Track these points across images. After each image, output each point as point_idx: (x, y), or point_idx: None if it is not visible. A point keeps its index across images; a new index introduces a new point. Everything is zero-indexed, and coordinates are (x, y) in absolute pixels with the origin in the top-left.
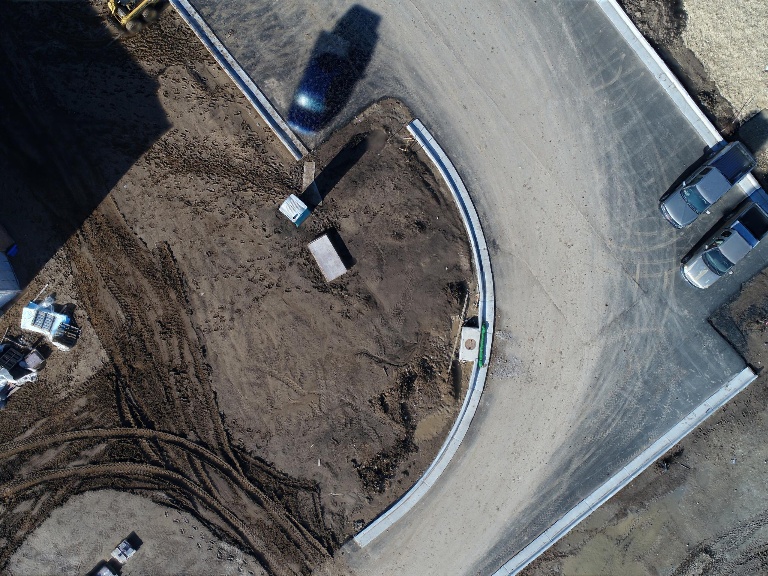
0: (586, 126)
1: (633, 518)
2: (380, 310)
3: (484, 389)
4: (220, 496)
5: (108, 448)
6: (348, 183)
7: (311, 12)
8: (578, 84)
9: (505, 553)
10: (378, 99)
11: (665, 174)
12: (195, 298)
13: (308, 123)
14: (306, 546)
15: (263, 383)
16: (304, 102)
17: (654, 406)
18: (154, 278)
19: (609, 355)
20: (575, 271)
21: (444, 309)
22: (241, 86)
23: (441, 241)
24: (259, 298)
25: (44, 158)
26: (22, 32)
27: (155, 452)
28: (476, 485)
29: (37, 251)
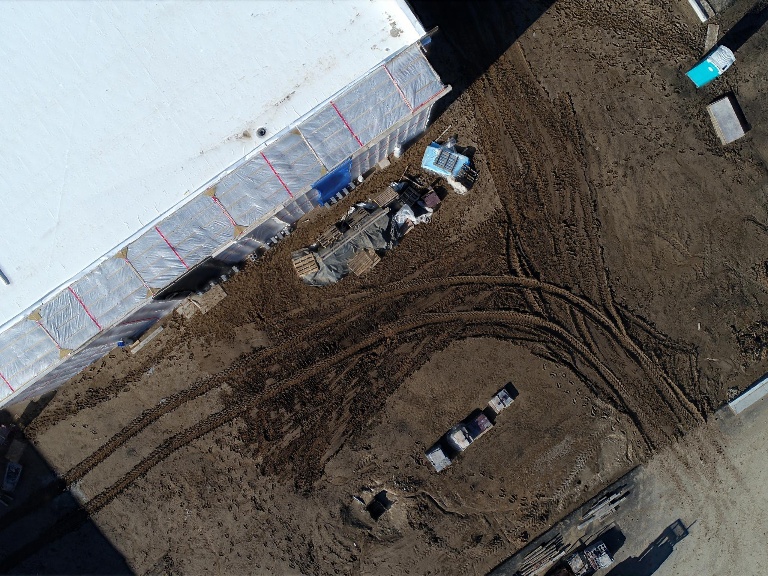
0: None
1: None
2: None
3: None
4: (599, 352)
5: (492, 296)
6: (751, 48)
7: None
8: None
9: None
10: None
11: None
12: (590, 152)
13: None
14: (680, 409)
15: (650, 242)
16: None
17: None
18: (553, 128)
19: None
20: None
21: None
22: None
23: None
24: (653, 157)
25: None
26: None
27: (539, 303)
28: None
29: None
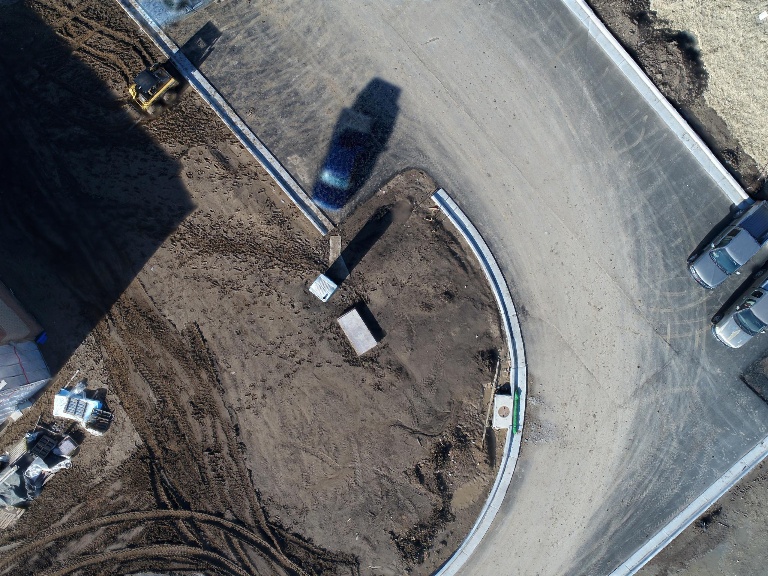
0: (611, 189)
1: None
2: (412, 381)
3: (519, 456)
4: (259, 574)
5: (145, 531)
6: (375, 256)
7: (331, 86)
8: (601, 147)
9: None
10: (401, 170)
11: (692, 233)
12: (226, 377)
13: (332, 198)
14: None
15: (297, 459)
16: (328, 177)
17: (690, 466)
18: (184, 359)
19: (643, 416)
20: (606, 334)
21: (476, 377)
22: (264, 164)
23: (470, 310)
24: (290, 374)
25: (70, 244)
26: (43, 120)
27: (192, 533)
28: (515, 552)
29: (66, 337)
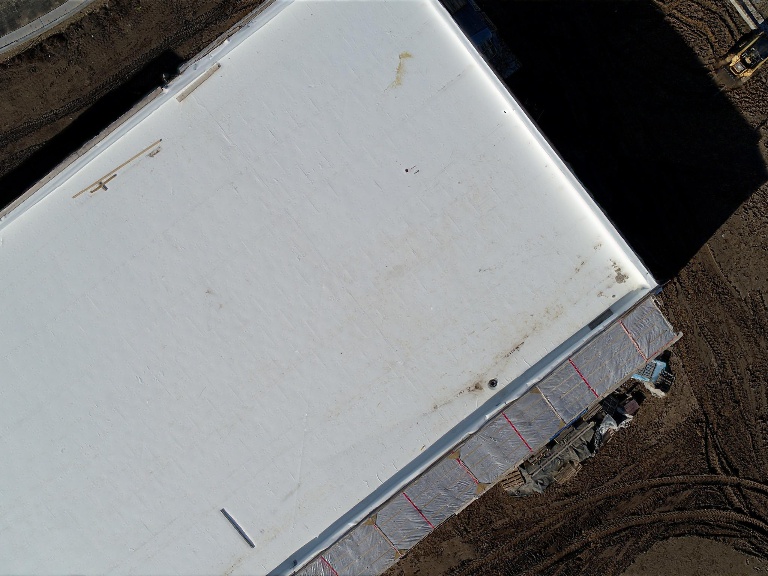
0: None
1: None
2: None
3: None
4: None
5: (693, 495)
6: None
7: None
8: None
9: None
10: None
11: None
12: None
13: None
14: None
15: None
16: None
17: None
18: (745, 326)
19: None
20: None
21: None
22: None
23: None
24: None
25: (646, 206)
26: (632, 82)
27: (739, 499)
28: None
29: None
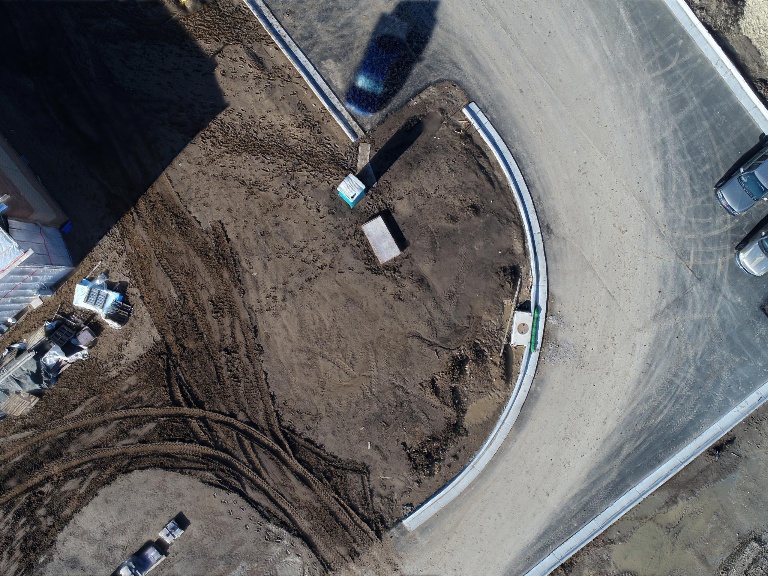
0: (642, 112)
1: (683, 506)
2: (433, 293)
3: (535, 374)
4: (269, 477)
5: (158, 427)
6: (403, 165)
7: None
8: (635, 69)
9: (554, 539)
10: (434, 81)
11: (720, 161)
12: (248, 278)
13: (364, 104)
14: (354, 529)
15: (314, 364)
16: (360, 83)
17: (706, 394)
18: (207, 257)
19: (661, 342)
20: (629, 257)
21: (497, 293)
22: (298, 66)
23: (495, 225)
24: (312, 279)
25: (100, 135)
26: (81, 8)
27: (205, 432)
28: (526, 470)
29: (91, 228)
